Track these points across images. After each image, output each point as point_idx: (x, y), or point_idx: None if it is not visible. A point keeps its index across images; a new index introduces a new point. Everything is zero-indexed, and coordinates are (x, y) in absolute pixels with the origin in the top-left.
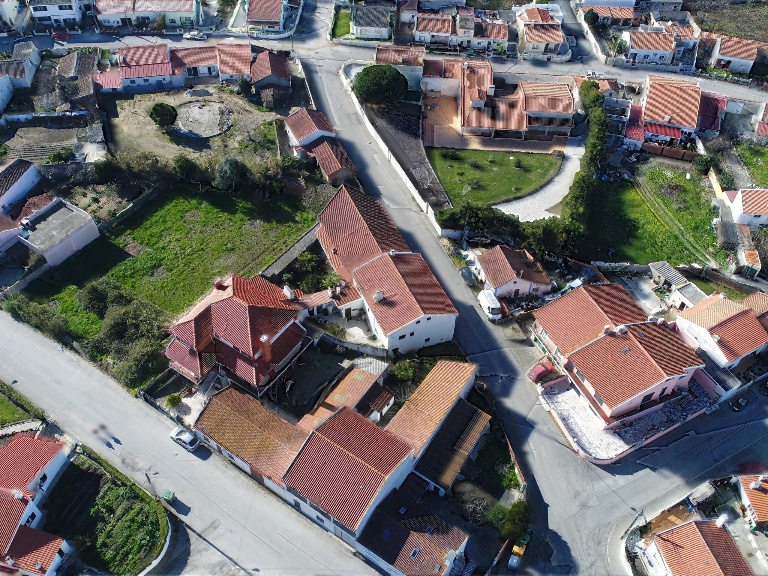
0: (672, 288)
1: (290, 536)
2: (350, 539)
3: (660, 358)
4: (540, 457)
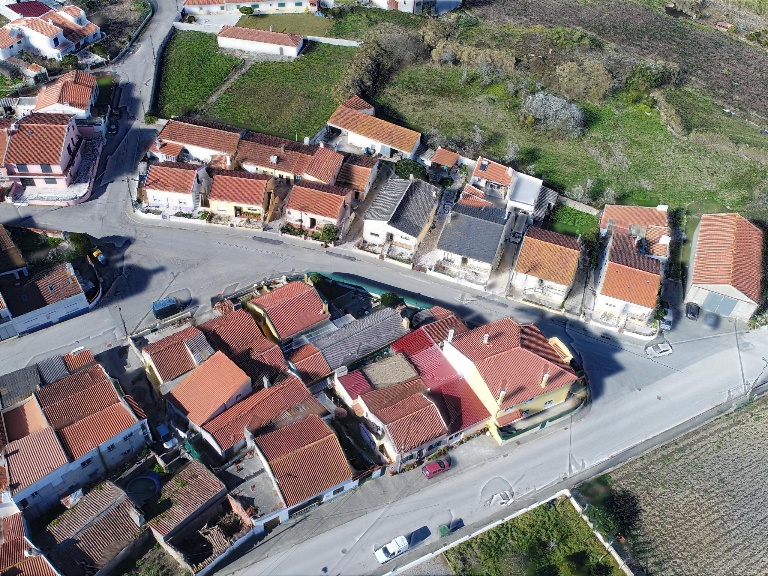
0: (13, 108)
1: None
2: (8, 330)
3: (52, 123)
4: (53, 223)
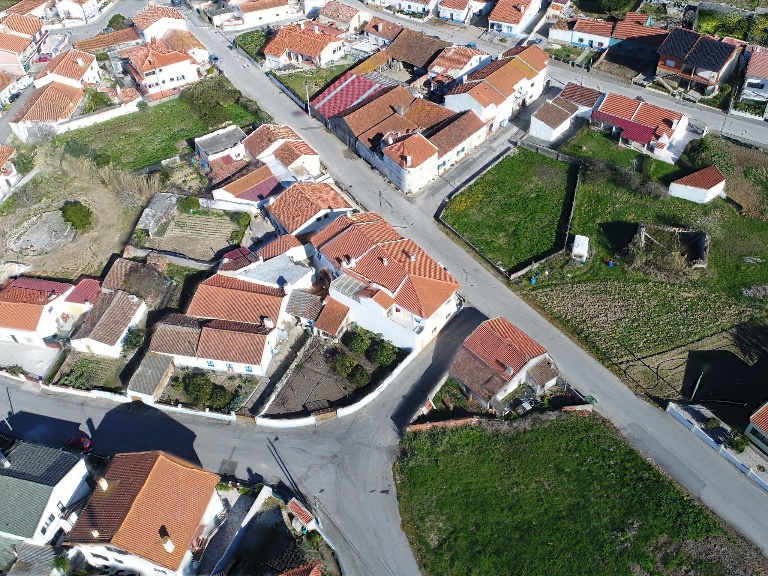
0: None
1: (198, 36)
2: None
3: None
4: None
